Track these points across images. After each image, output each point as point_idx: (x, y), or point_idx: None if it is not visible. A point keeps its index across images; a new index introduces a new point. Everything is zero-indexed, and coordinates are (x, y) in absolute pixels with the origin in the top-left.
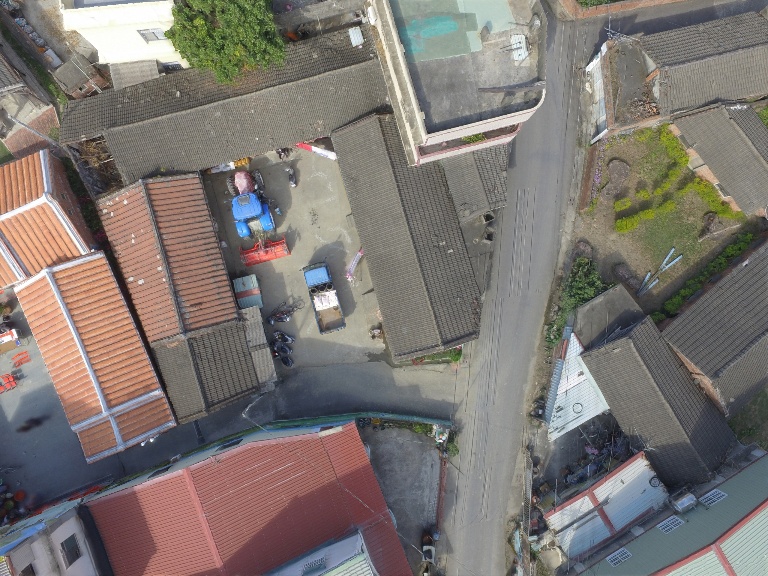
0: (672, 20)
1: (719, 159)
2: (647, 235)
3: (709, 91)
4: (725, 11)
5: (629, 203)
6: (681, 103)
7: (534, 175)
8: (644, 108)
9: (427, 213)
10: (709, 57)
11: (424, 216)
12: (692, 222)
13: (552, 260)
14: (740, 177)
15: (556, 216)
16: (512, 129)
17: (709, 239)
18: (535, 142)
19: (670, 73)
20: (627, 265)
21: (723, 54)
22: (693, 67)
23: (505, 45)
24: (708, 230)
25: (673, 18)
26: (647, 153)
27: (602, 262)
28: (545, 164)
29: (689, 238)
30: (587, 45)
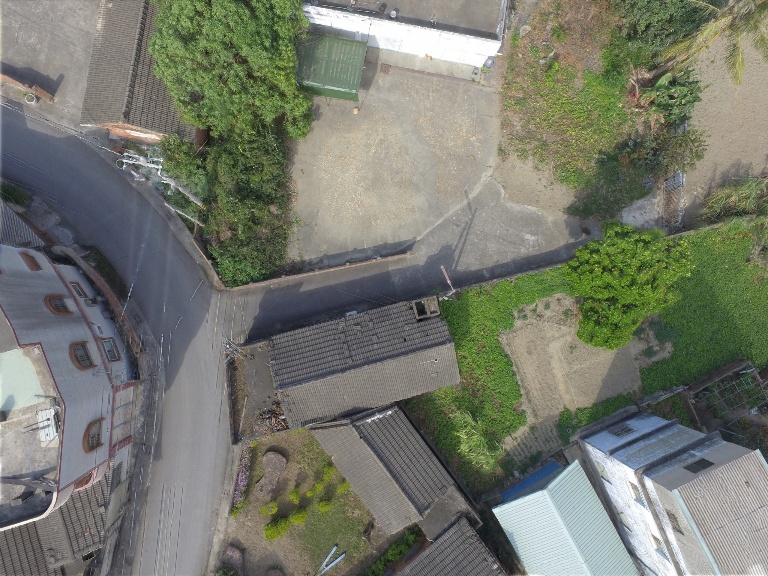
0: (342, 288)
1: (356, 476)
2: (307, 533)
3: (342, 403)
4: (401, 276)
5: (275, 509)
6: (314, 414)
7: (182, 468)
8: (270, 422)
9: (8, 560)
10: (330, 376)
11: (3, 565)
12: (357, 515)
13: (201, 563)
14: (377, 497)
15: (207, 513)
16: (86, 479)
17: (373, 536)
18: (184, 430)
19: (288, 393)
20: (283, 567)
21: (346, 372)
22: (314, 385)
23: (30, 423)
24: (372, 526)
25: (343, 285)
26: (308, 441)
27: (256, 565)
28: (195, 455)
29: (353, 534)
30: (245, 318)
